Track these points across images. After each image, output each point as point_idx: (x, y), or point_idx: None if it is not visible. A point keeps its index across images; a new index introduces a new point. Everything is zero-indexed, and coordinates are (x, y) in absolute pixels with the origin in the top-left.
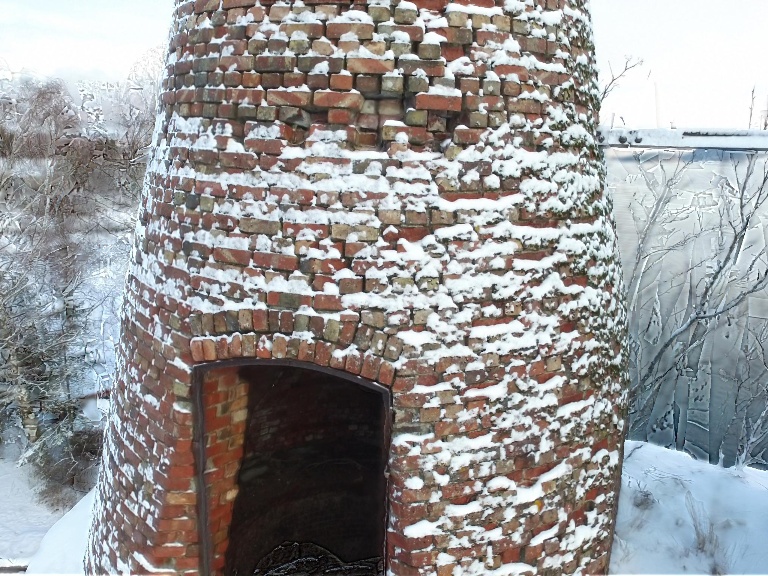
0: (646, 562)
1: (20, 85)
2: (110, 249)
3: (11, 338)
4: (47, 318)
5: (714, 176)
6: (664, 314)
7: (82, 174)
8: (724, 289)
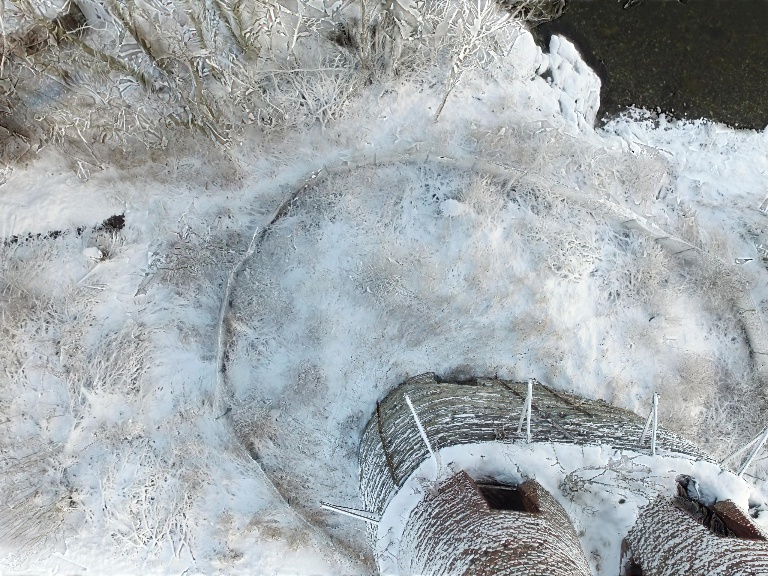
0: None
1: None
2: None
3: None
4: None
5: None
6: None
7: None
8: None
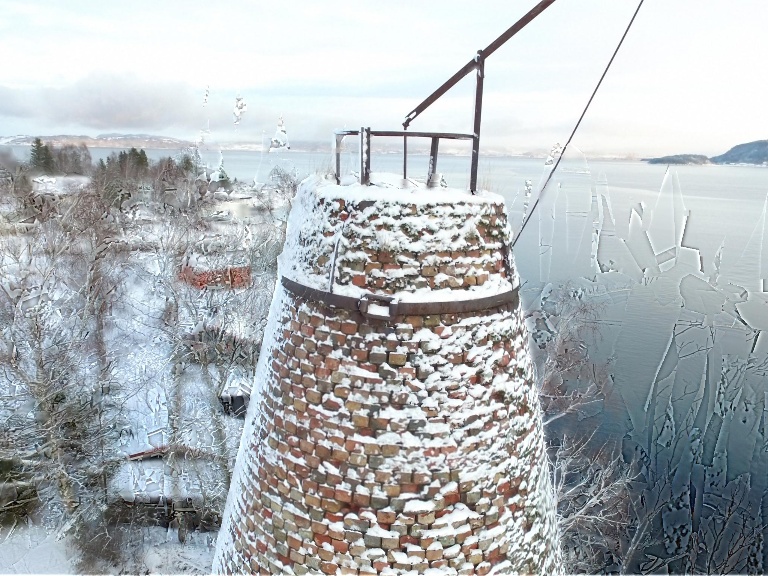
0: None
1: (63, 187)
2: (145, 355)
3: (52, 429)
4: (86, 416)
5: (726, 299)
6: (677, 419)
7: (119, 273)
8: (740, 384)
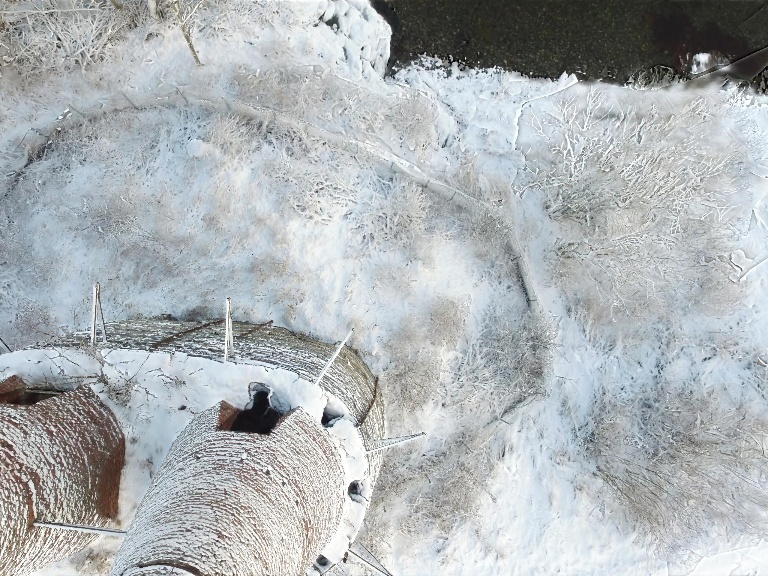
0: (132, 475)
1: None
2: None
3: None
4: None
5: None
6: None
7: None
8: None
